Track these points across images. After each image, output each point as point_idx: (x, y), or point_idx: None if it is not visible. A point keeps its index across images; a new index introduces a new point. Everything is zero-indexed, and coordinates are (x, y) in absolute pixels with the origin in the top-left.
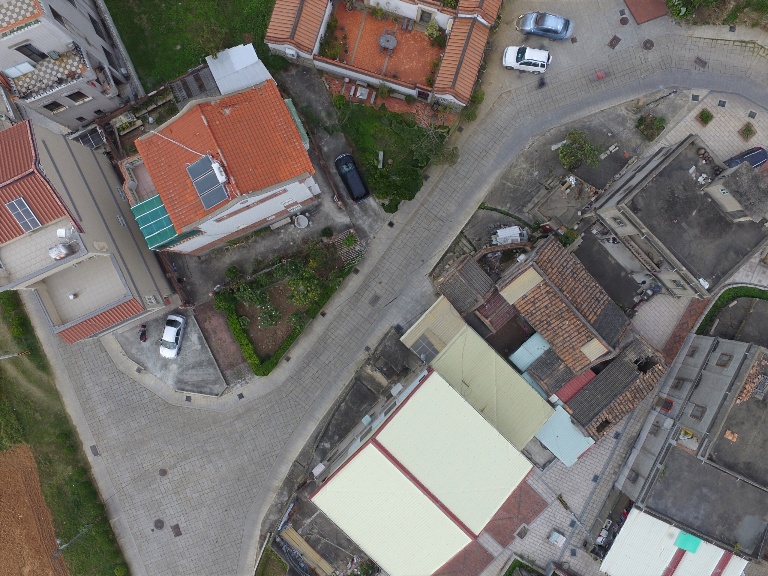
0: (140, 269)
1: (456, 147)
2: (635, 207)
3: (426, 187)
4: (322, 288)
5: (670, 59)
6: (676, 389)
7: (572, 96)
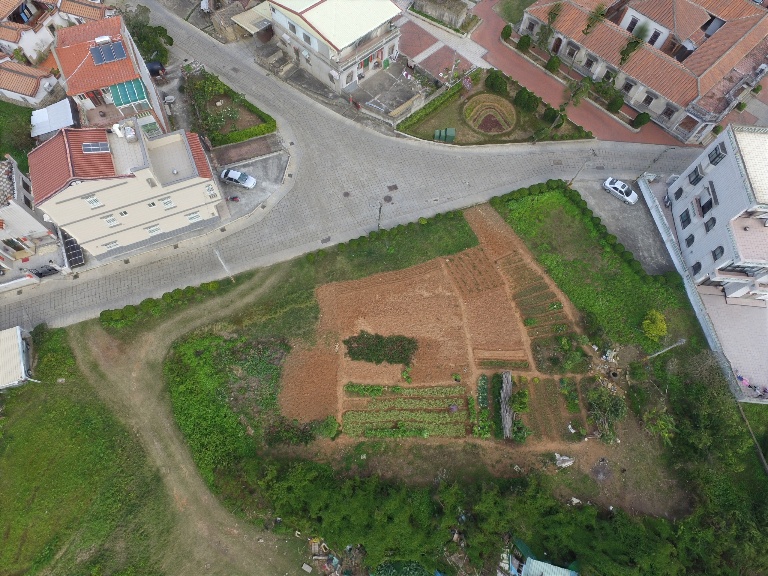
0: None
1: None
2: None
3: None
4: None
5: None
6: None
7: None
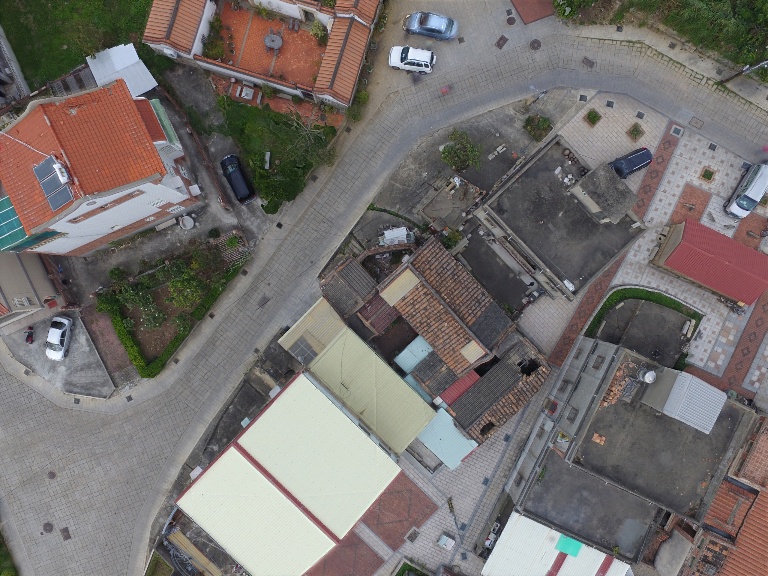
0: (13, 271)
1: (333, 148)
2: (501, 208)
3: (315, 188)
4: (205, 290)
5: (558, 59)
6: (561, 391)
7: (460, 96)
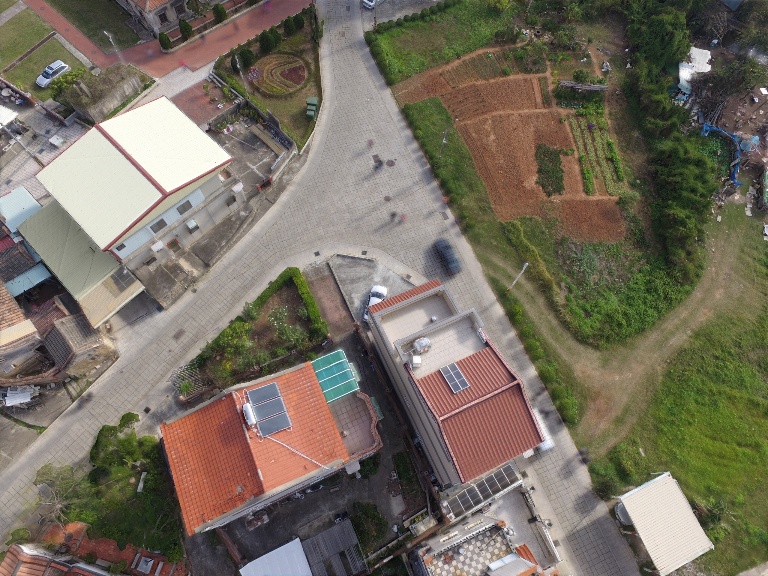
0: None
1: None
2: None
3: None
4: None
5: None
6: None
7: None
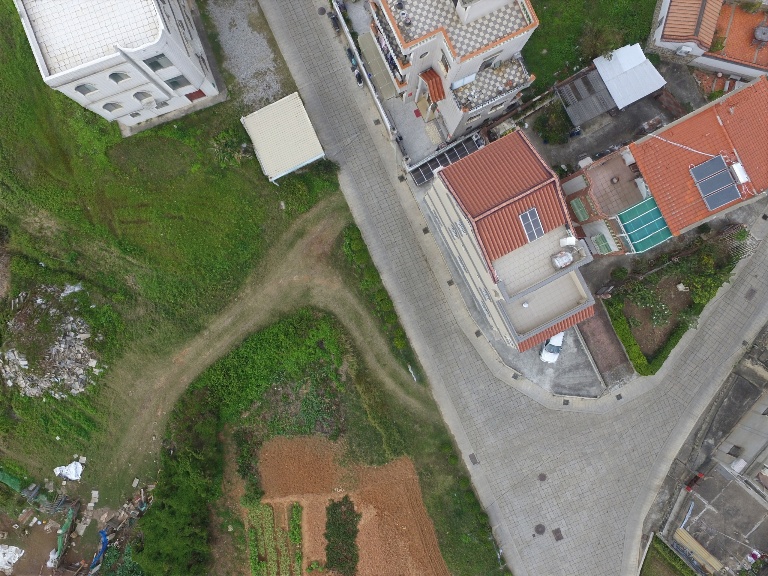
0: None
1: None
2: None
3: None
4: None
5: None
6: None
7: None
